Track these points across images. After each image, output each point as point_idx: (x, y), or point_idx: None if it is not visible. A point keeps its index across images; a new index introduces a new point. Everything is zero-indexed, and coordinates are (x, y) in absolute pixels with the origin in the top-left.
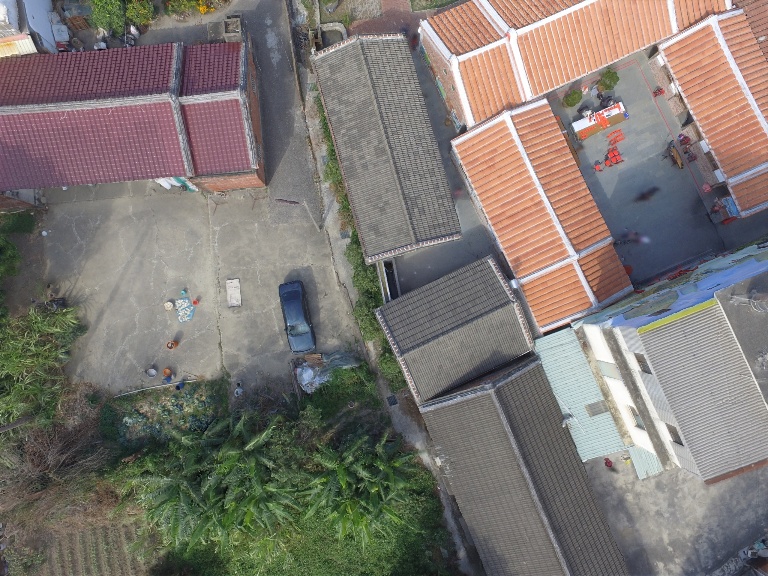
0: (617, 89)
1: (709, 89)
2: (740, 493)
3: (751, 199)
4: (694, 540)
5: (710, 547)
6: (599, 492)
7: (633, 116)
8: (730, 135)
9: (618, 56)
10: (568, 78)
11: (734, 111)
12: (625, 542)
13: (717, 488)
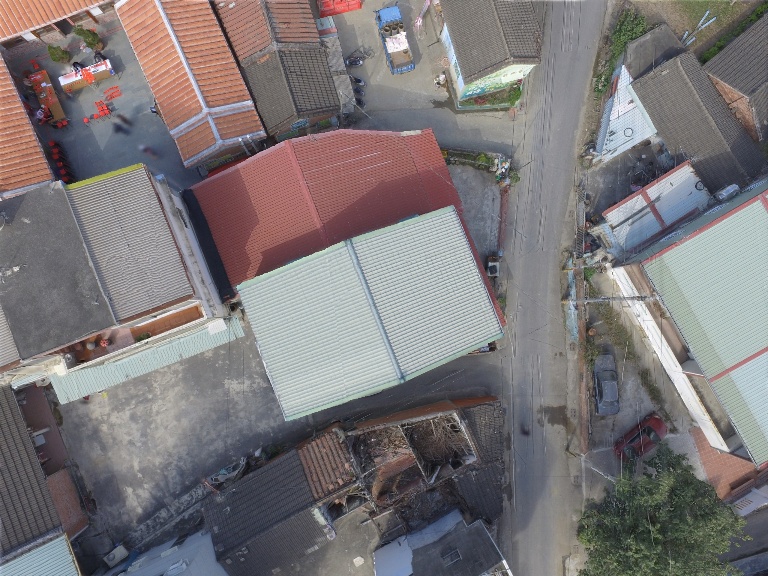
0: (117, 48)
1: (152, 47)
2: (211, 424)
3: (190, 150)
4: (163, 467)
5: (179, 474)
6: (76, 423)
7: (130, 74)
8: (169, 90)
9: (66, 13)
10: (14, 31)
11: (171, 68)
12: (98, 469)
13: (189, 420)
